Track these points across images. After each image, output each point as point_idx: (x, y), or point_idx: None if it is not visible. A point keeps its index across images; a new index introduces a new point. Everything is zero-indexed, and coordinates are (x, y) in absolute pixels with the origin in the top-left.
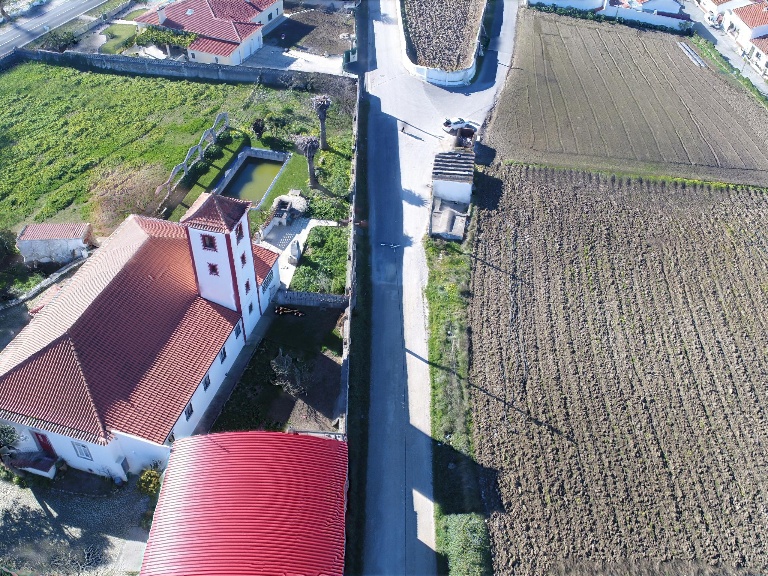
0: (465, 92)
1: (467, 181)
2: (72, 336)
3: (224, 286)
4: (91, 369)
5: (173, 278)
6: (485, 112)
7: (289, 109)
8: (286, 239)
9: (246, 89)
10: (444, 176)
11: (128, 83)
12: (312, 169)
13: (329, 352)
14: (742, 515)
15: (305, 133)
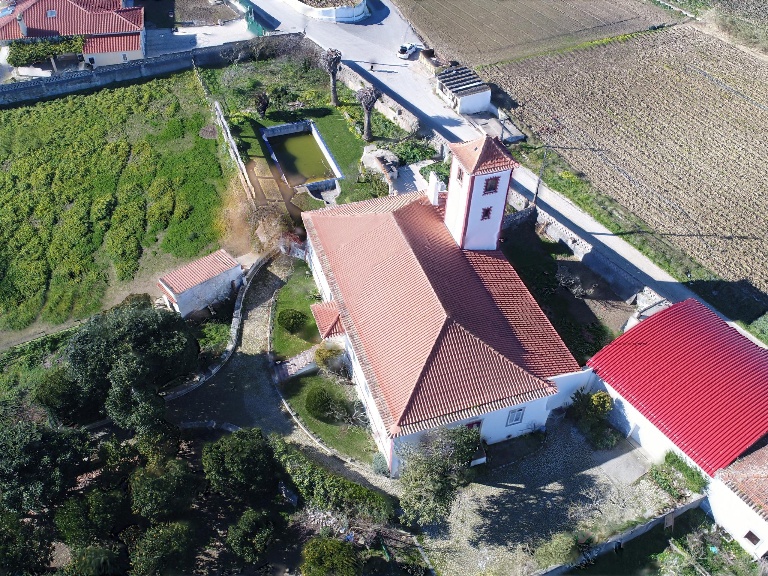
0: (376, 22)
1: (487, 89)
2: (452, 318)
3: (491, 228)
4: (486, 339)
5: (436, 242)
6: (412, 34)
7: (257, 82)
8: (411, 189)
9: (184, 78)
10: (466, 92)
11: (34, 113)
12: (369, 121)
13: (560, 256)
14: None
15: (301, 98)
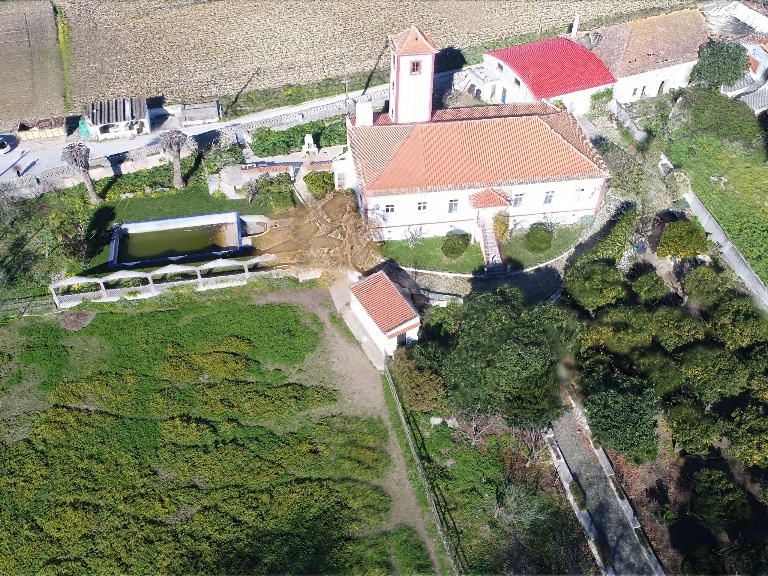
0: None
1: (143, 99)
2: None
3: None
4: None
5: None
6: None
7: None
8: None
9: None
10: (139, 111)
11: None
12: None
13: None
14: (394, 3)
15: None
